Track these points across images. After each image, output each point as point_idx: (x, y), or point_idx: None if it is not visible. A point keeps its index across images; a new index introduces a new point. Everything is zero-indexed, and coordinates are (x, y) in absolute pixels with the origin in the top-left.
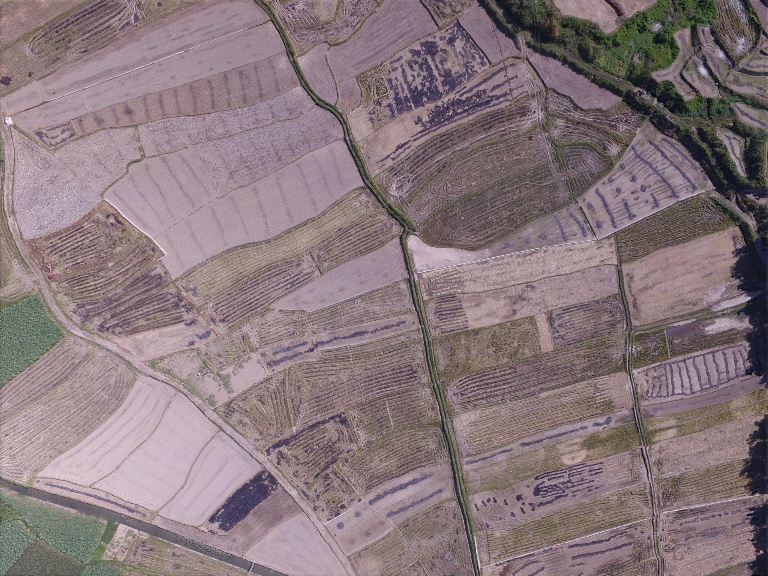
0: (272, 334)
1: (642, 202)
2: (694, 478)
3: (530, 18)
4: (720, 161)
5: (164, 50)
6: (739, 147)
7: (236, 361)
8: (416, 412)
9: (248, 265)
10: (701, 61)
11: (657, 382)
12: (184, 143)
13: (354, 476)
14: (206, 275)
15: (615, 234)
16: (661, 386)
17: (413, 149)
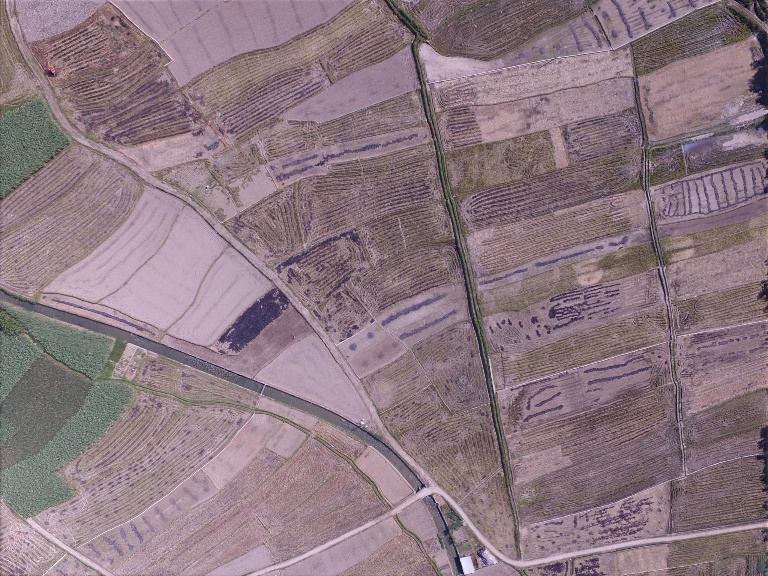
0: (281, 146)
1: (658, 11)
2: (712, 301)
3: None
4: None
5: None
6: None
7: (245, 174)
8: (429, 230)
9: (256, 73)
10: None
11: (674, 200)
12: None
13: (366, 296)
14: (213, 83)
15: (631, 44)
16: (678, 204)
17: None
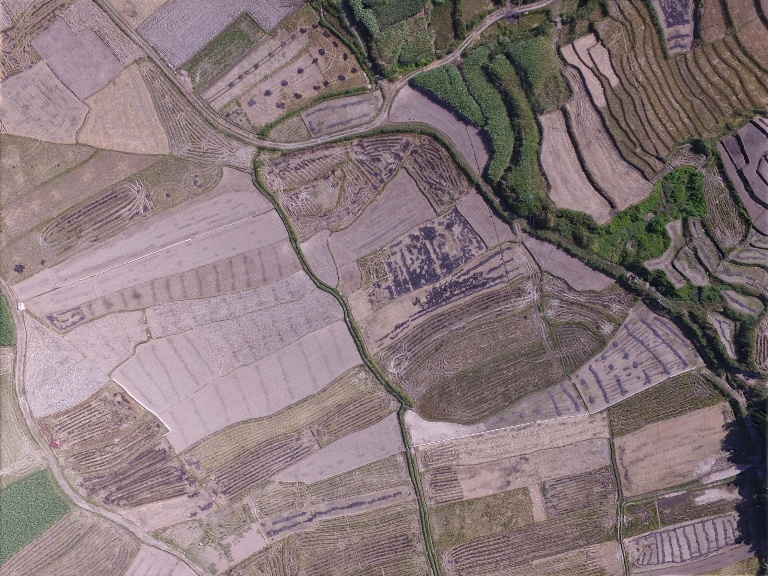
0: (272, 505)
1: (634, 378)
2: None
3: (526, 210)
4: (710, 342)
5: (172, 238)
6: (729, 330)
7: (237, 531)
8: None
9: (250, 440)
10: (692, 251)
11: (648, 550)
12: (189, 325)
13: None
14: (209, 449)
15: (607, 409)
16: (652, 554)
17: (411, 329)
